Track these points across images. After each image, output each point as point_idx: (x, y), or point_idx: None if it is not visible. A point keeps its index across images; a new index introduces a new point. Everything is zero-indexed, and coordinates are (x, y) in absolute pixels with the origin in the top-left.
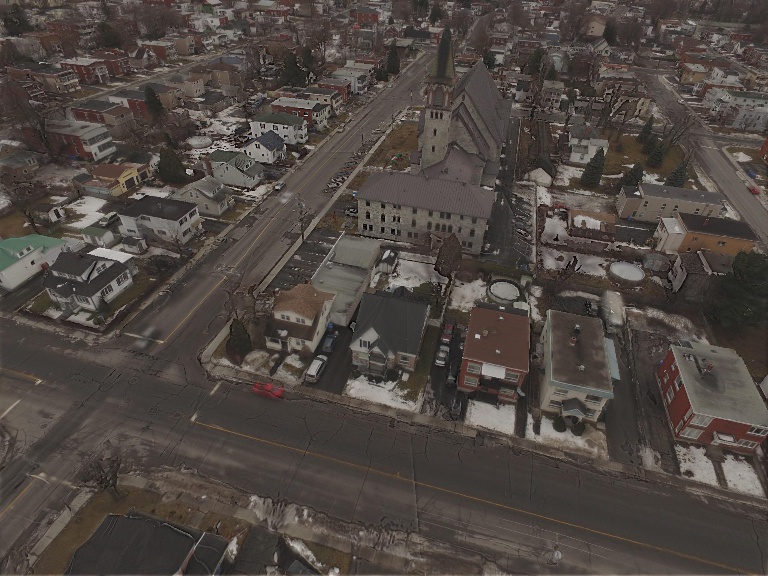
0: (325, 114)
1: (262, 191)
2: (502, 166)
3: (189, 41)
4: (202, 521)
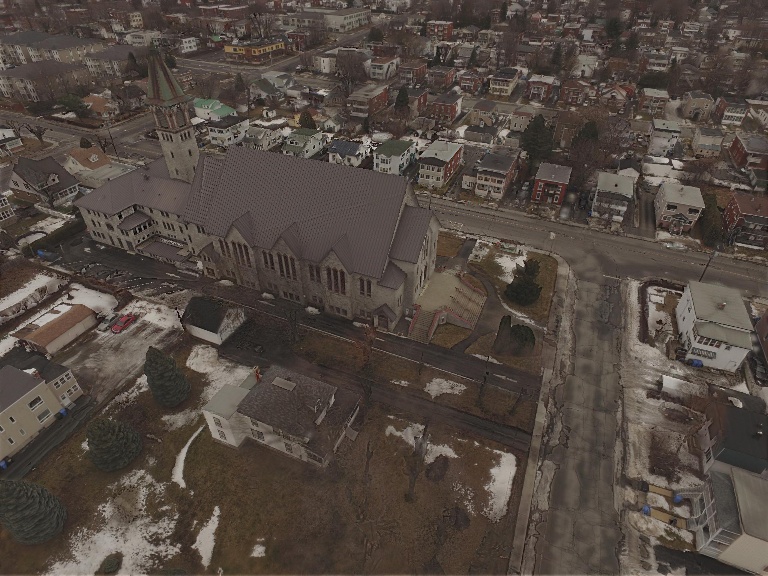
0: (438, 174)
1: None
2: (273, 299)
3: (699, 103)
4: (12, 157)
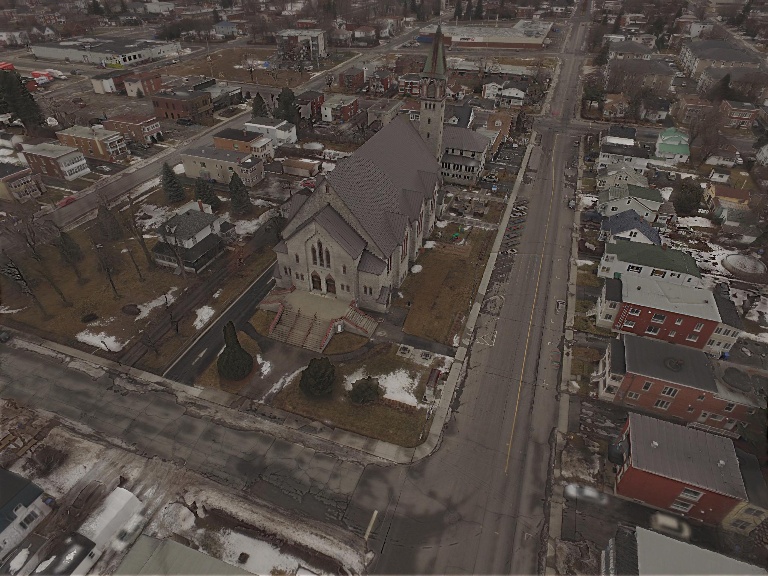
0: None
1: (585, 200)
2: None
3: None
4: None
